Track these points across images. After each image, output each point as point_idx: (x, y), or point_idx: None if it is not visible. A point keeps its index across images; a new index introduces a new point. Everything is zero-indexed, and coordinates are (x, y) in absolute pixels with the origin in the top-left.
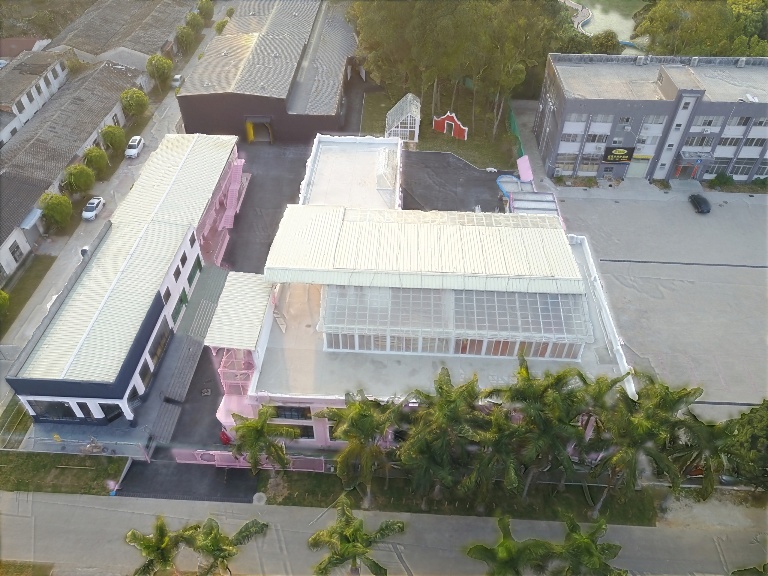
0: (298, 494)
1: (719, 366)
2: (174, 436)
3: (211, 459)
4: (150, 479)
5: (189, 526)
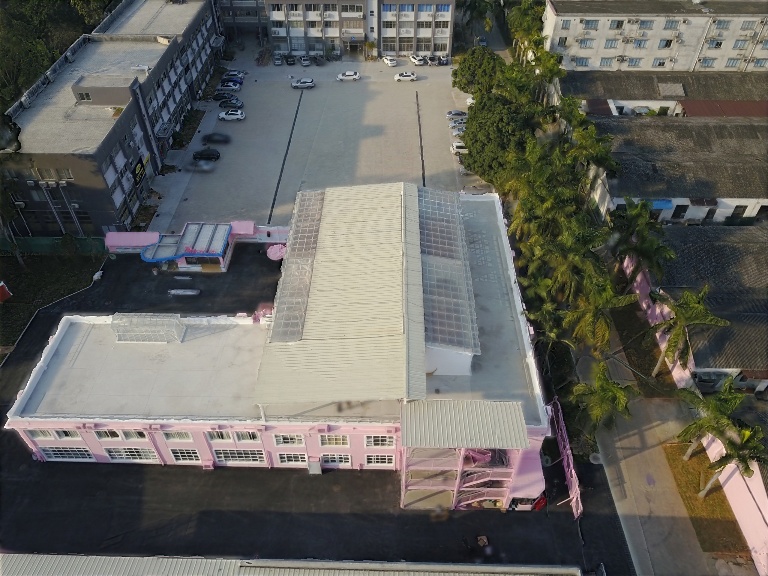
0: None
1: None
2: (550, 562)
3: (568, 513)
4: (612, 570)
5: (646, 514)
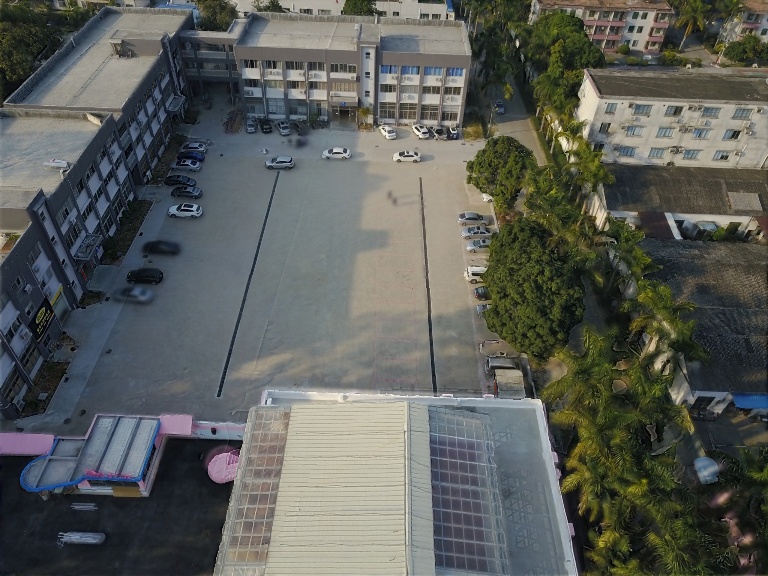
0: None
1: (388, 338)
2: None
3: None
4: None
5: None
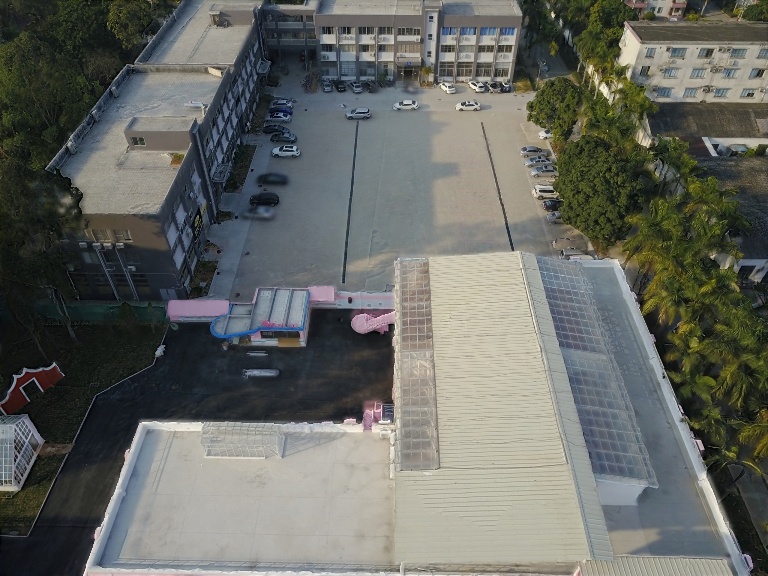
0: (759, 558)
1: (475, 240)
2: None
3: None
4: None
5: None
